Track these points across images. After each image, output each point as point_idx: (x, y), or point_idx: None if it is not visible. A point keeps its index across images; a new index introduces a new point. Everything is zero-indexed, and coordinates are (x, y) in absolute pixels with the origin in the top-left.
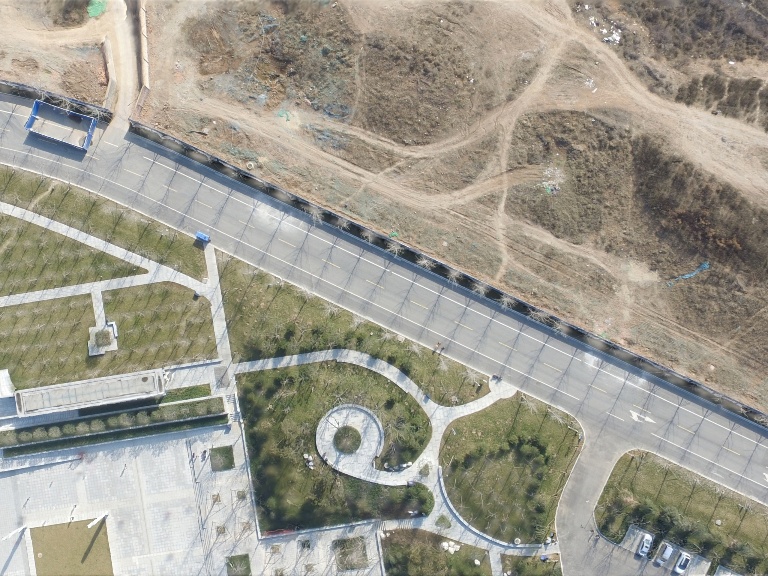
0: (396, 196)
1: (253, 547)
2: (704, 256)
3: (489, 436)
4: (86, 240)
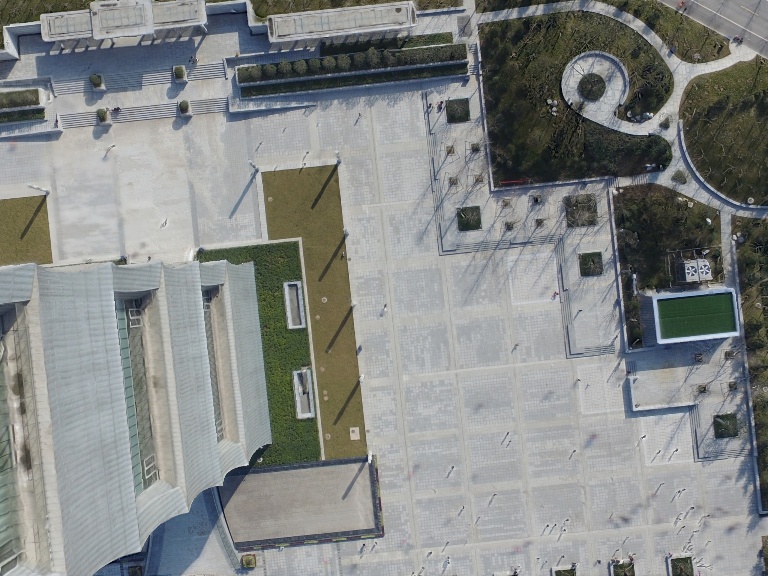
0: None
1: (484, 200)
2: None
3: (731, 91)
4: None
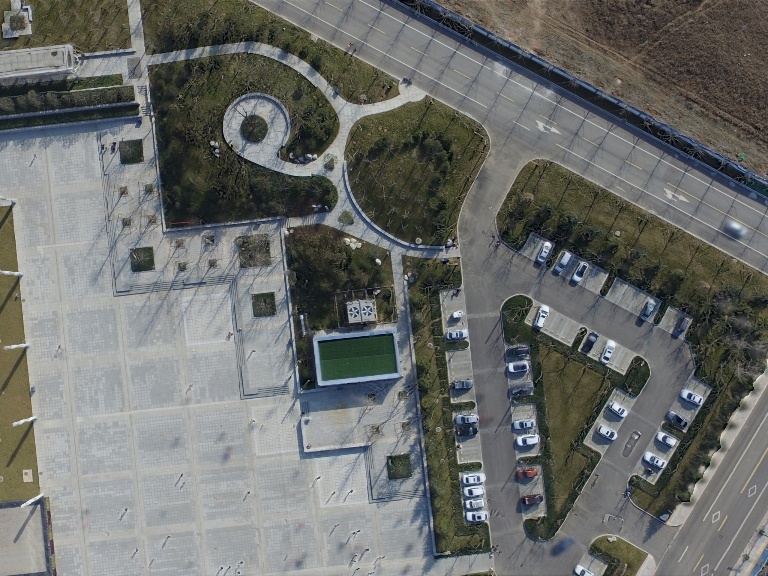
0: None
1: (158, 240)
2: None
3: (395, 133)
4: None
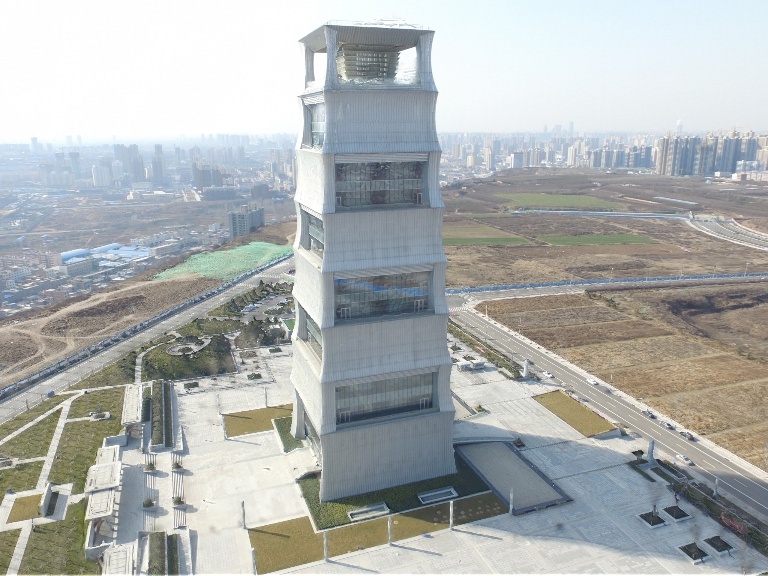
0: (61, 355)
1: None
2: (127, 306)
3: None
4: None
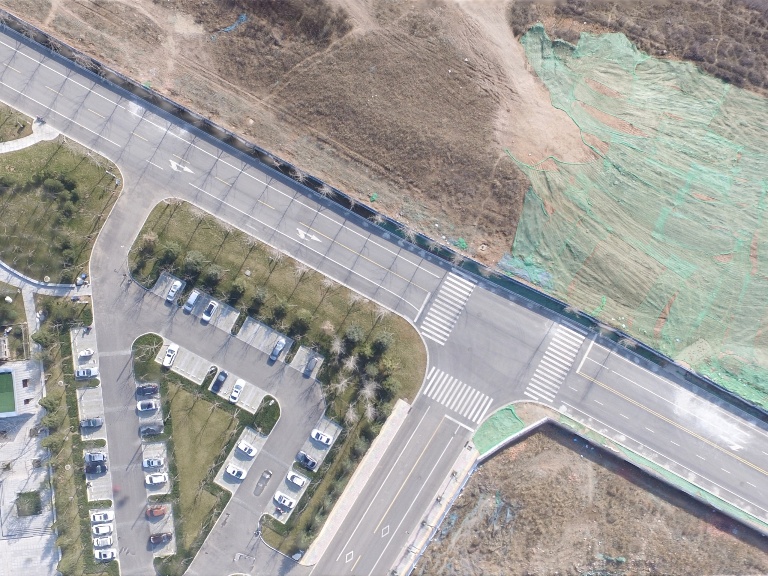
0: None
1: None
2: (241, 7)
3: (21, 172)
4: None
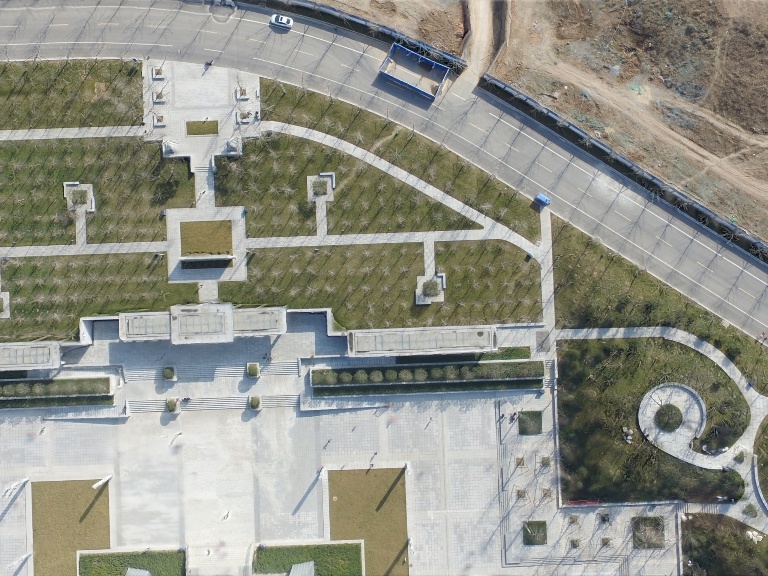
0: (737, 182)
1: (551, 515)
2: None
3: None
4: (424, 189)
